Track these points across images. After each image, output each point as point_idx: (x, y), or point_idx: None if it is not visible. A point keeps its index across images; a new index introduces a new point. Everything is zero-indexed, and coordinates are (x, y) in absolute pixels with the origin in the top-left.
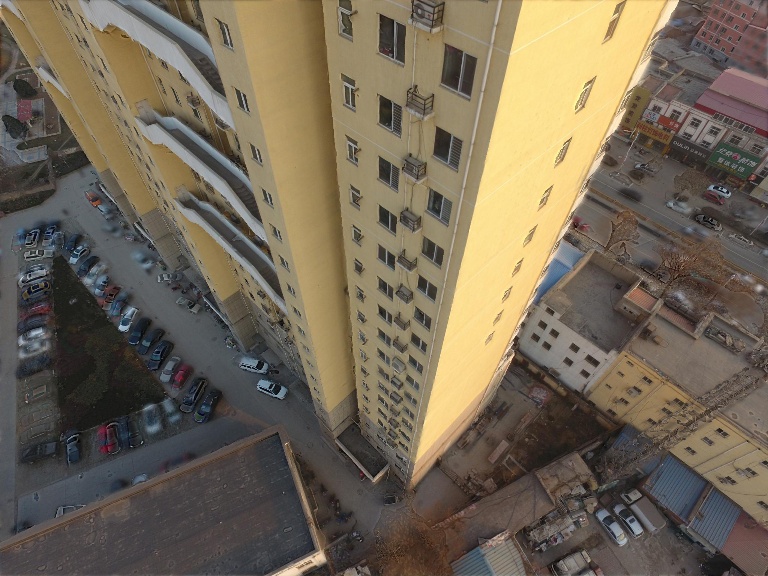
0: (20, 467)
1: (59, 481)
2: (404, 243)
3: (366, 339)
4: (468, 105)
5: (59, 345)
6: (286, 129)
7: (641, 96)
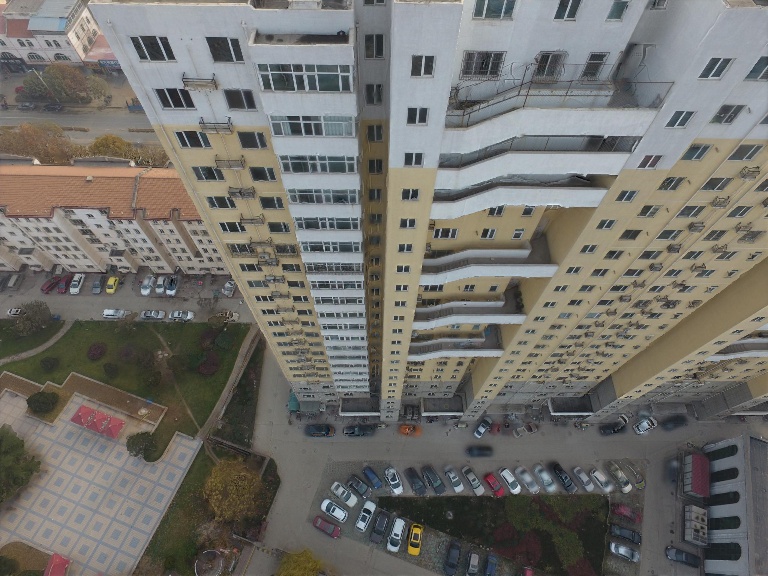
0: None
1: None
2: None
3: None
4: None
5: (501, 549)
6: None
7: None
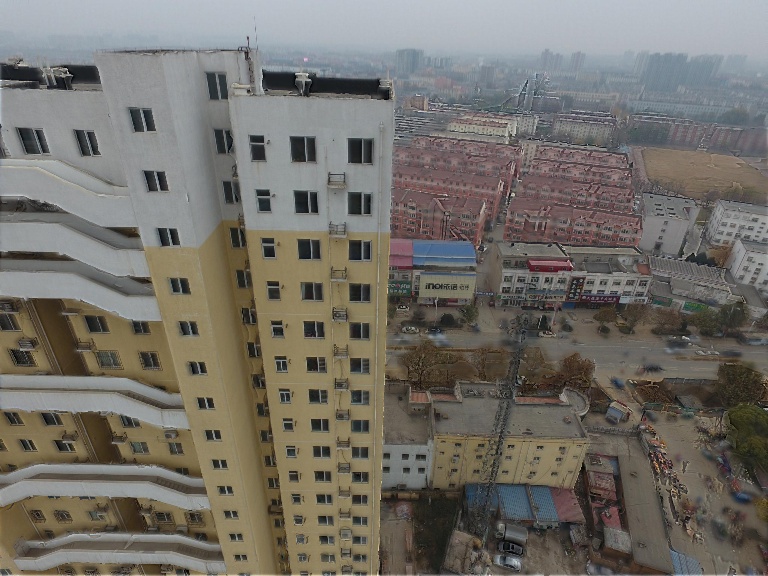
0: None
1: None
2: (337, 433)
3: (306, 537)
4: (369, 342)
5: None
6: (236, 406)
7: None
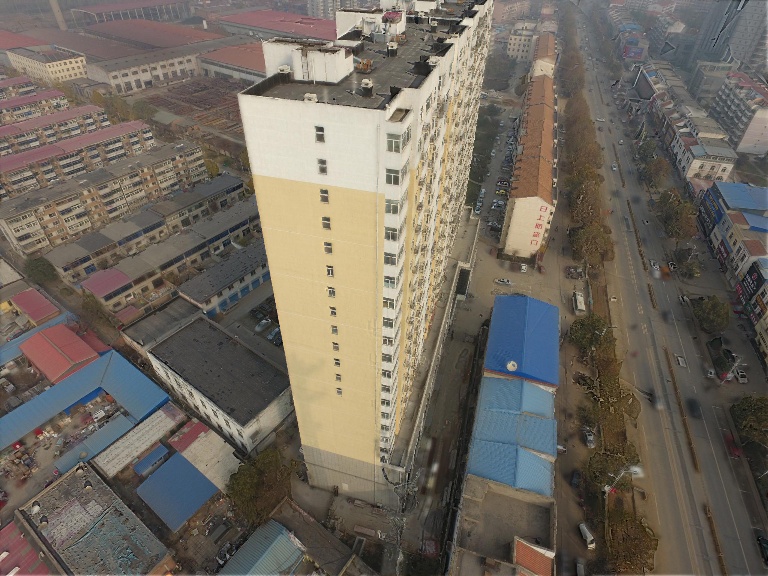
0: (249, 313)
1: (248, 329)
2: None
3: None
4: None
5: None
6: None
7: None
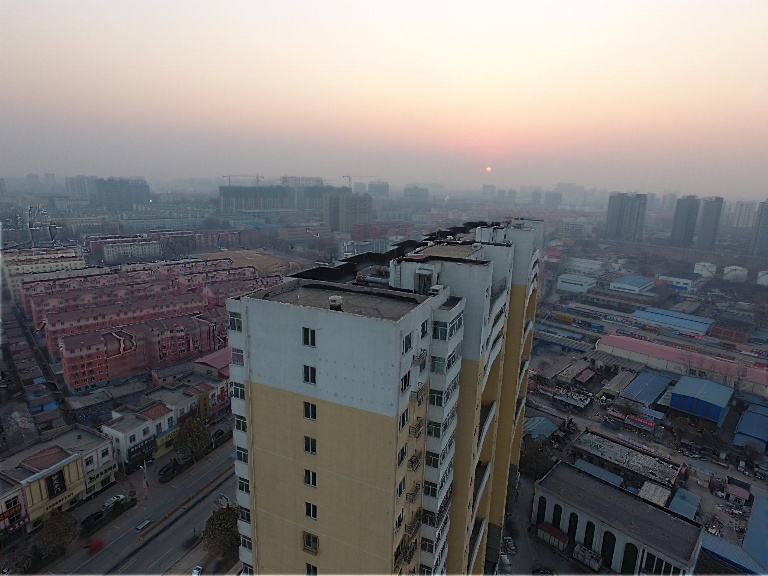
0: None
1: None
2: None
3: None
4: None
5: None
6: None
7: (205, 397)
